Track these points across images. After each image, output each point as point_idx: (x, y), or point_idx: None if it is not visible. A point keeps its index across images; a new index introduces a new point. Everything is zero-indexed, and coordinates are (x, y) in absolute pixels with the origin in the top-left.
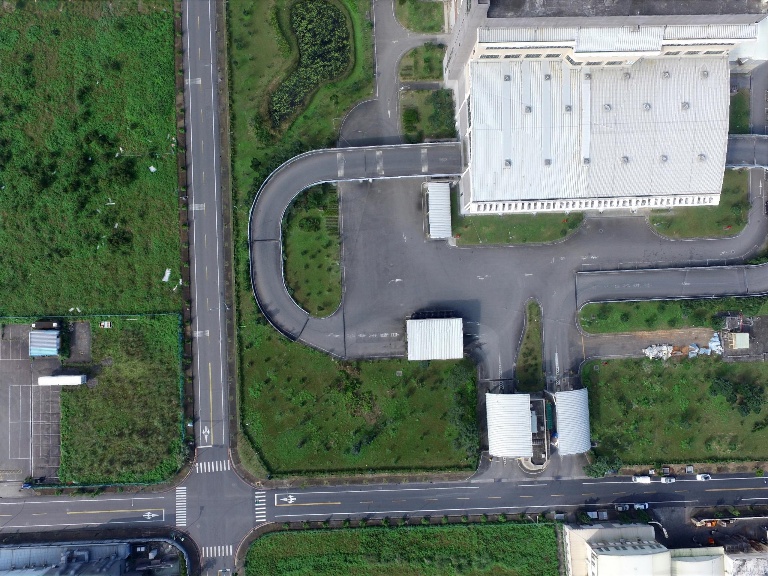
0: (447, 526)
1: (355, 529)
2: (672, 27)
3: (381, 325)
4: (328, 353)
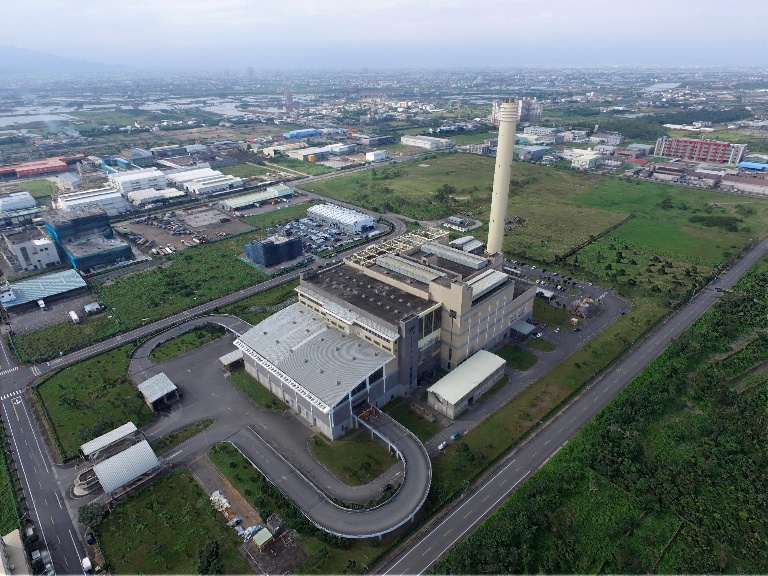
0: (7, 472)
1: None
2: (363, 317)
3: None
4: (128, 371)
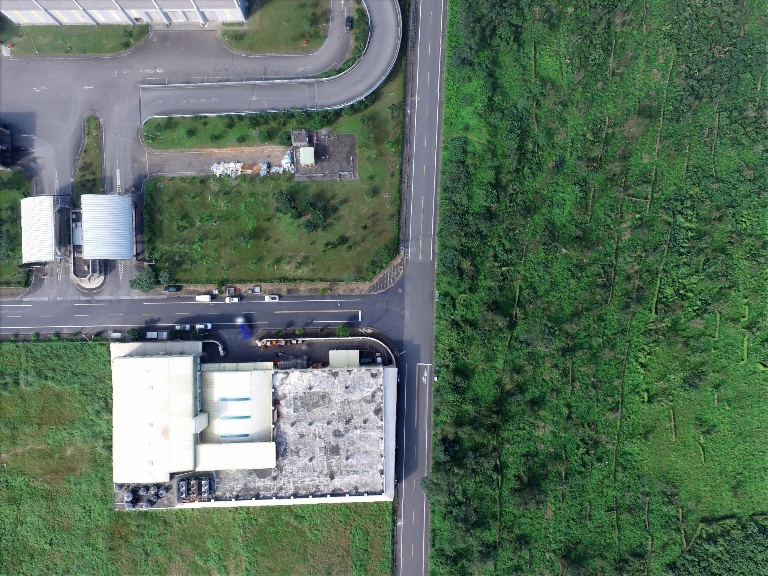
0: None
1: None
2: None
3: None
4: None
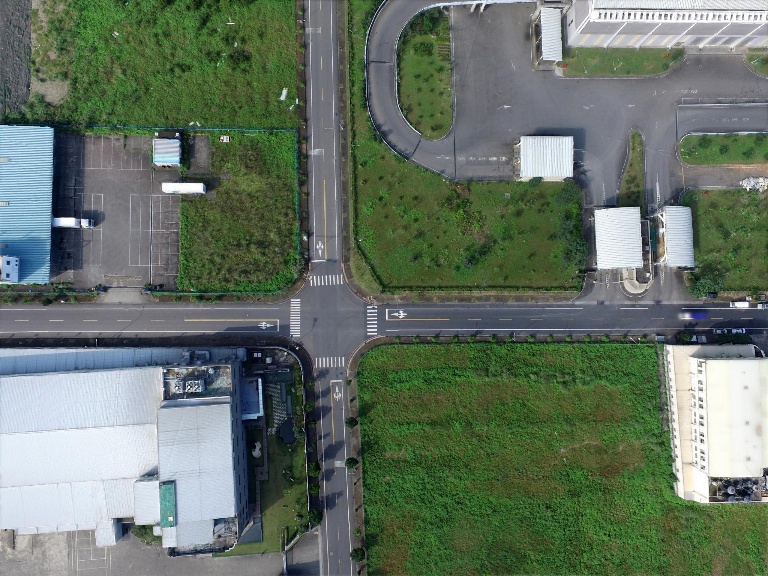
0: (553, 344)
1: (464, 344)
2: None
3: (490, 149)
4: (439, 174)
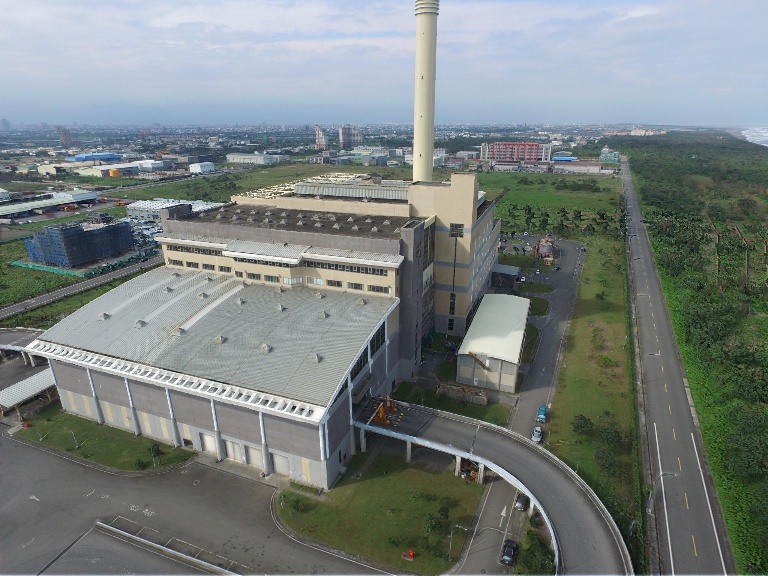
0: None
1: None
2: (317, 248)
3: None
4: None
